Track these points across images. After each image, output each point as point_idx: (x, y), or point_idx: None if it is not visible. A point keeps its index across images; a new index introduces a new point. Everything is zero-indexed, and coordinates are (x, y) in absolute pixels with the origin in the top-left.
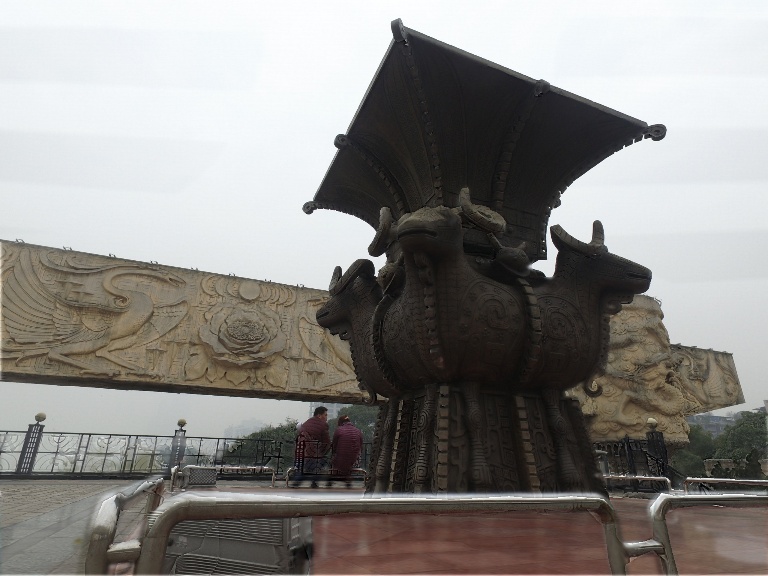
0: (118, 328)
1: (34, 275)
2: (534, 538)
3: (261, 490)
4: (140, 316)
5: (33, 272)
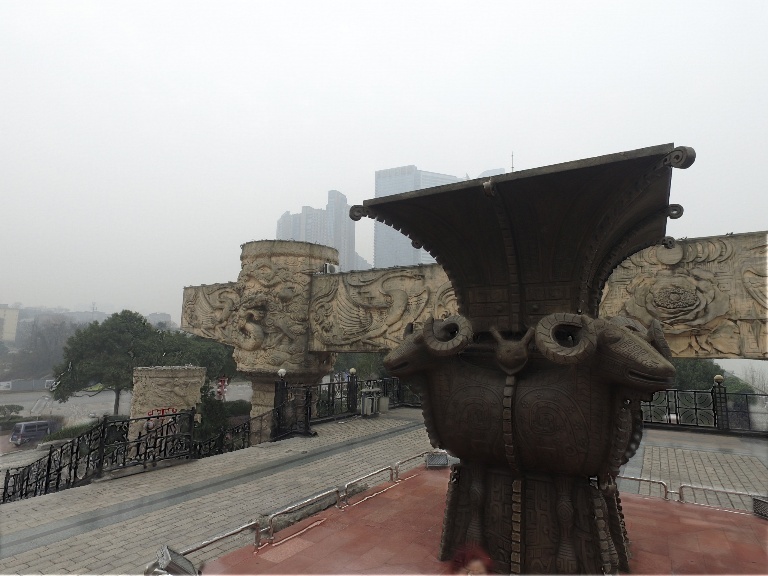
0: None
1: None
2: (640, 514)
3: None
4: None
5: None
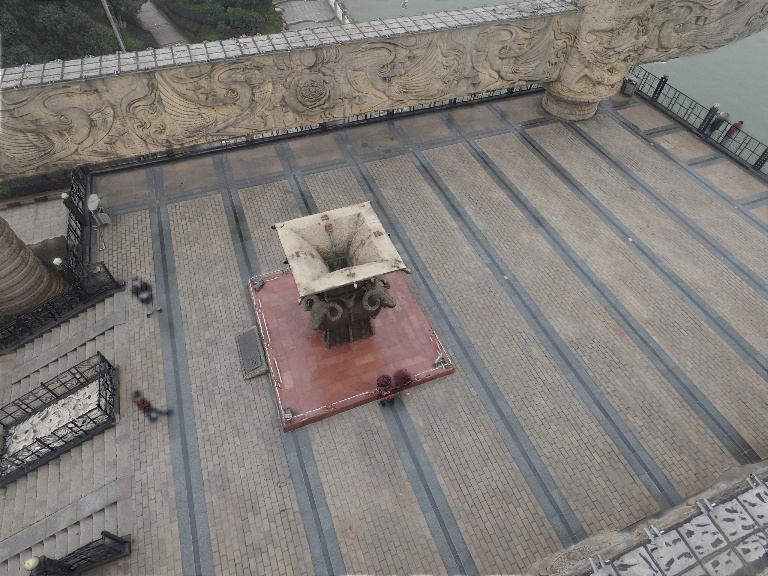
0: None
1: None
2: None
3: (413, 359)
4: None
5: None
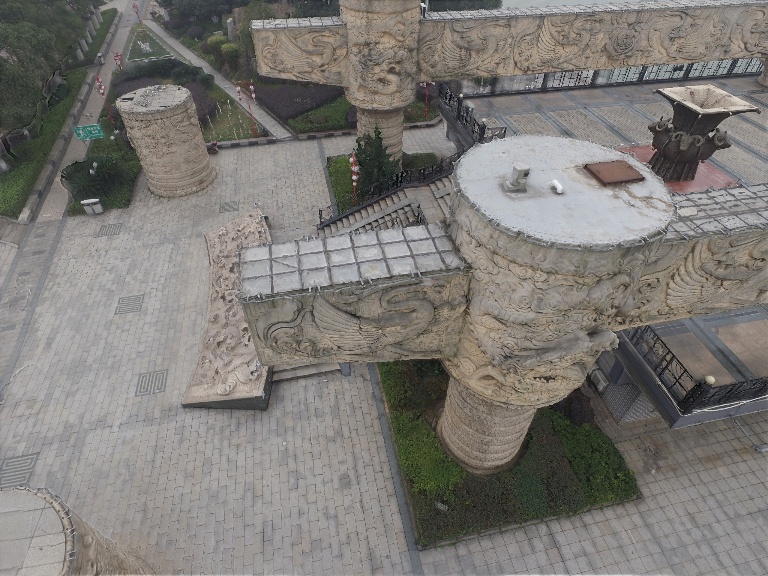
0: None
1: None
2: None
3: None
4: None
5: None
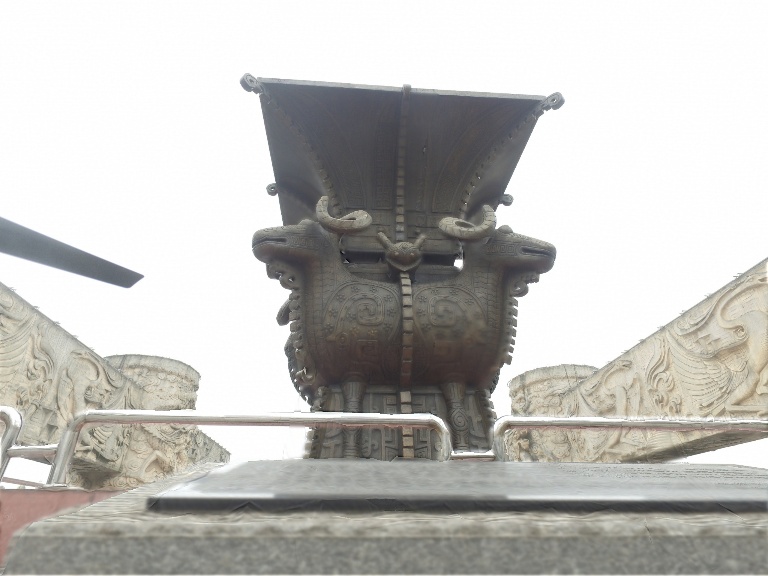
0: (753, 359)
1: (680, 347)
2: None
3: None
4: (761, 336)
5: (678, 345)
